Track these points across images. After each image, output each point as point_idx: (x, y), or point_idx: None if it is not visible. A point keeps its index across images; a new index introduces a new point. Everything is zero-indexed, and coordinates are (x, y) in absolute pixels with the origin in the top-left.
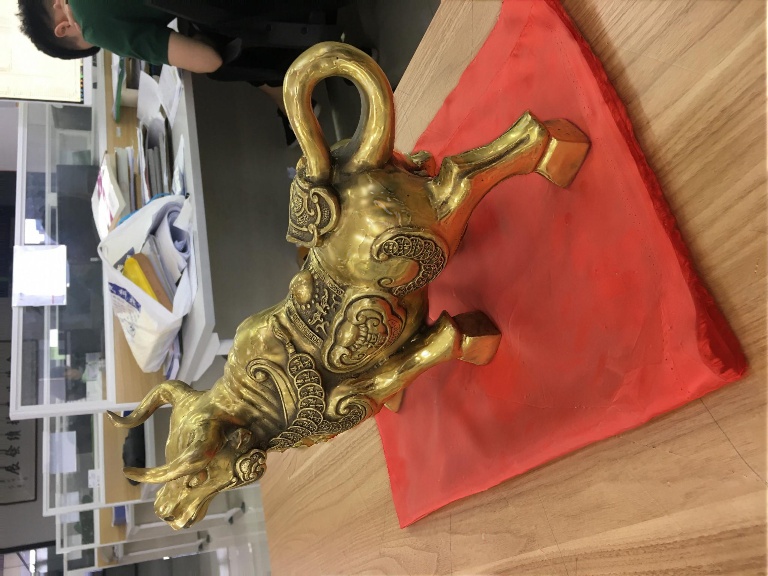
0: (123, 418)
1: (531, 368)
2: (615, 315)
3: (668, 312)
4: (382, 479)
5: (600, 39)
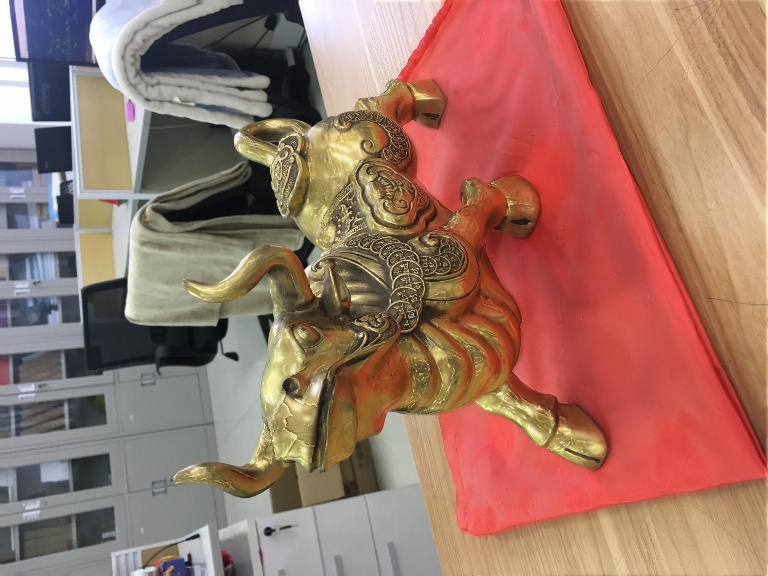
0: None
1: (537, 124)
2: (499, 23)
3: None
4: (717, 556)
5: None
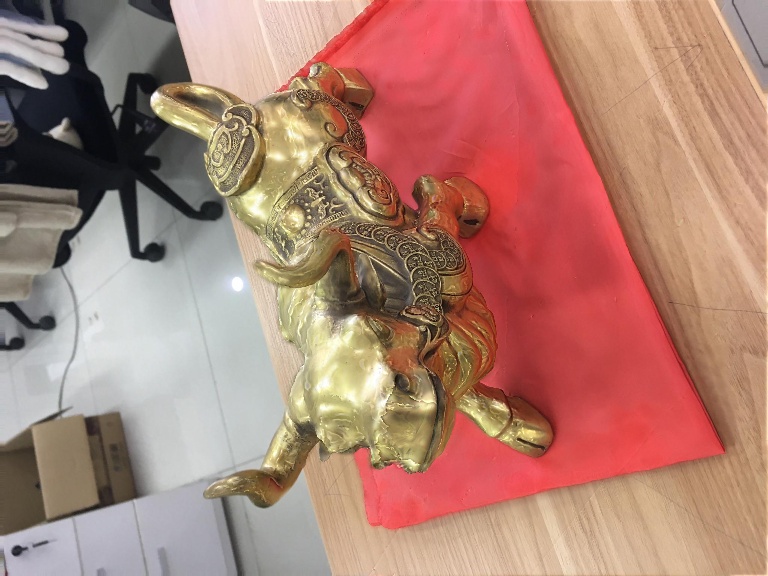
0: None
1: (490, 130)
2: (451, 27)
3: None
4: (663, 524)
5: None
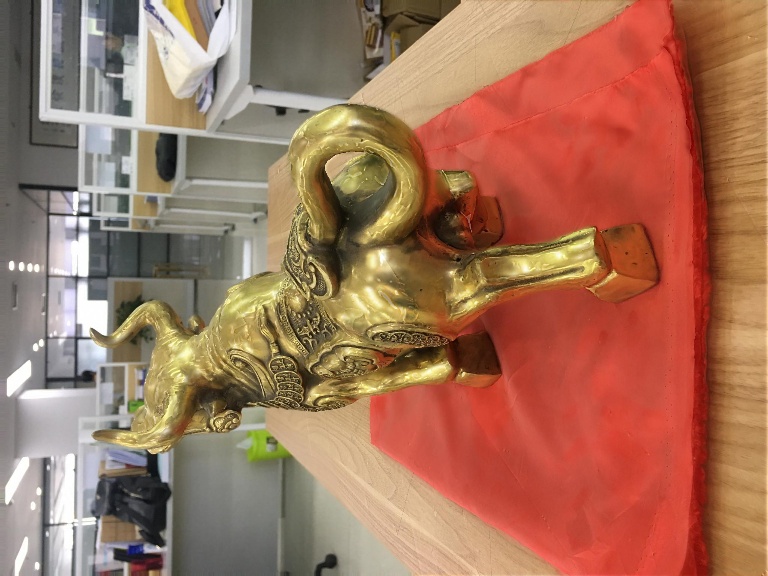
0: (106, 338)
1: (518, 431)
2: (611, 471)
3: (658, 536)
4: None
5: (722, 167)
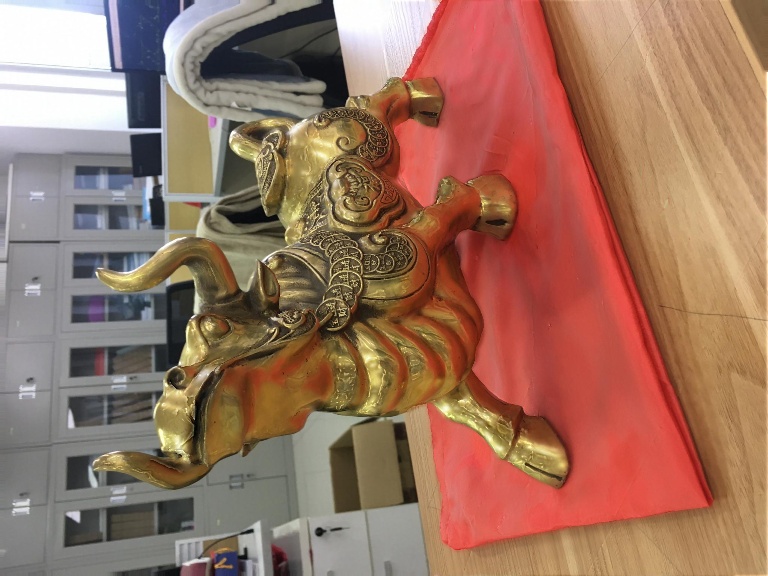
0: None
1: (516, 120)
2: (487, 17)
3: None
4: None
5: None
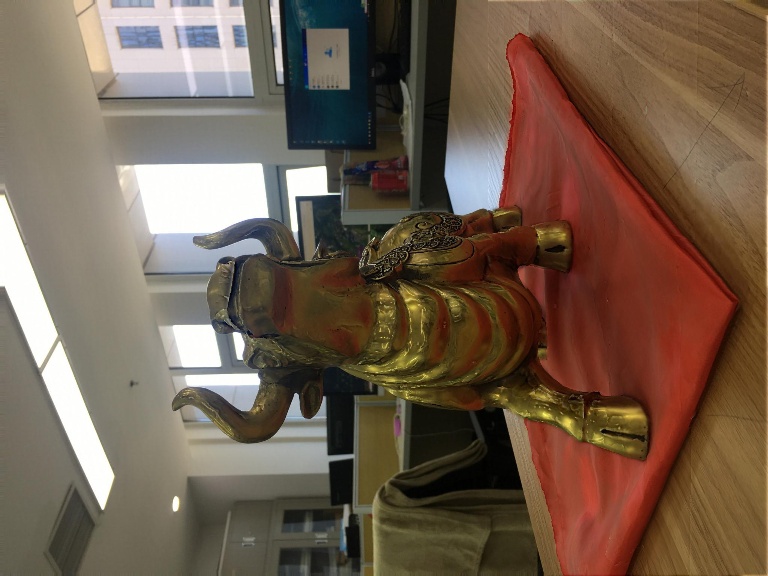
0: None
1: (560, 170)
2: (533, 124)
3: None
4: (743, 459)
5: None
